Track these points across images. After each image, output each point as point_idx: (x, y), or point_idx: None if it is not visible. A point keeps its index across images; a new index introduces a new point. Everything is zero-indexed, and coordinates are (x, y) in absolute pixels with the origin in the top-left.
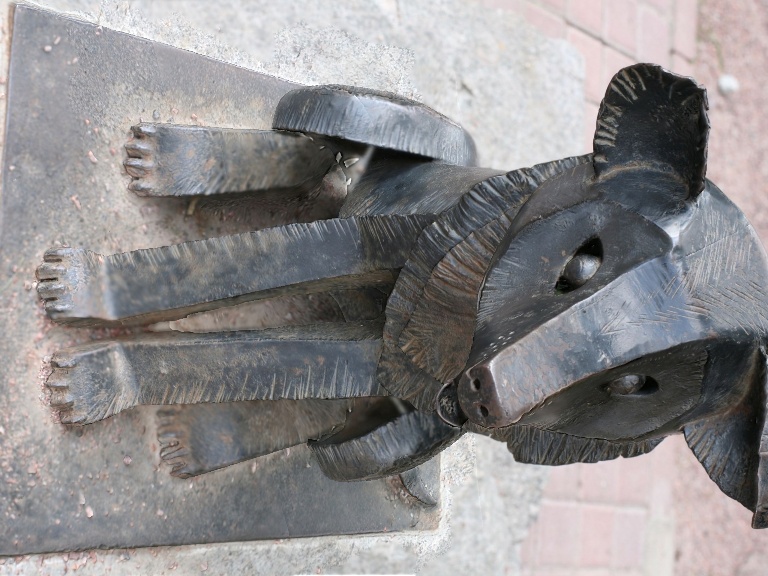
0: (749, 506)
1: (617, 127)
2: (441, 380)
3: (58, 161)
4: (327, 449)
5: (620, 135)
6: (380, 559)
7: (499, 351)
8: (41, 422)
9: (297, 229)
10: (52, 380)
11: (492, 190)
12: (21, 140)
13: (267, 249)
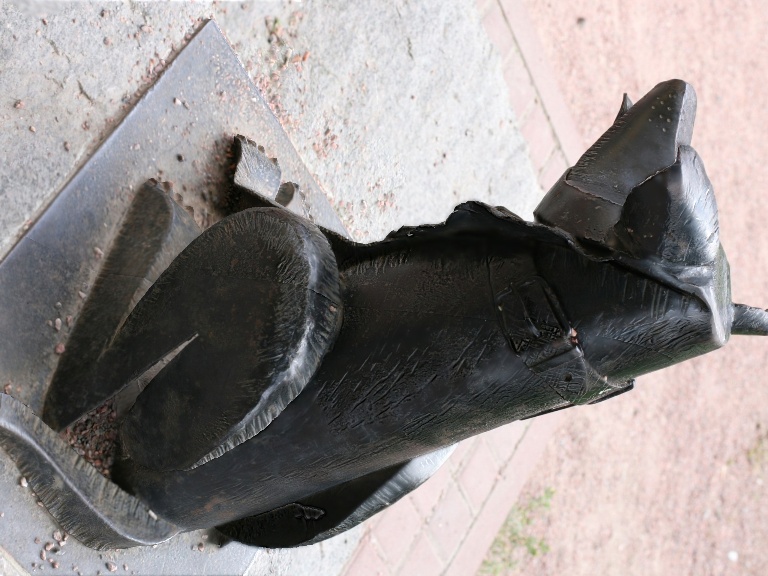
0: None
1: None
2: None
3: None
4: None
5: None
6: None
7: None
8: (239, 127)
9: None
10: None
11: None
12: None
13: None
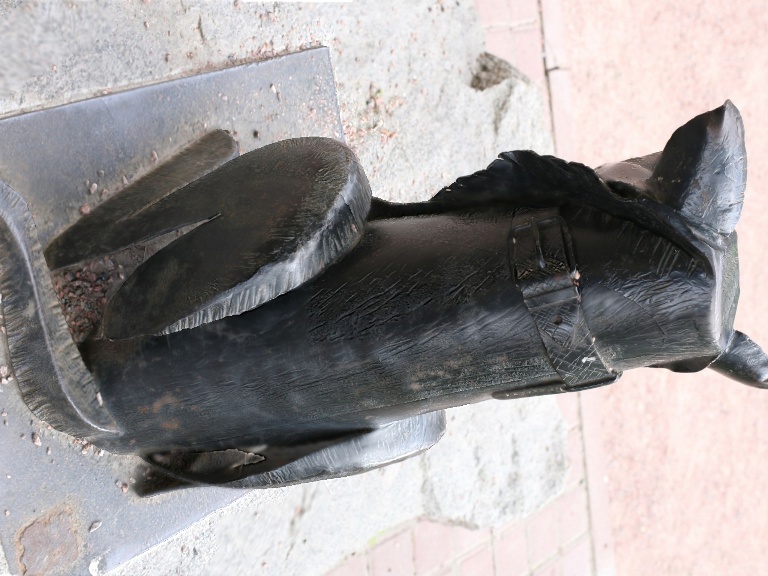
0: None
1: None
2: None
3: None
4: None
5: None
6: None
7: None
8: None
9: None
10: None
11: None
12: None
13: None
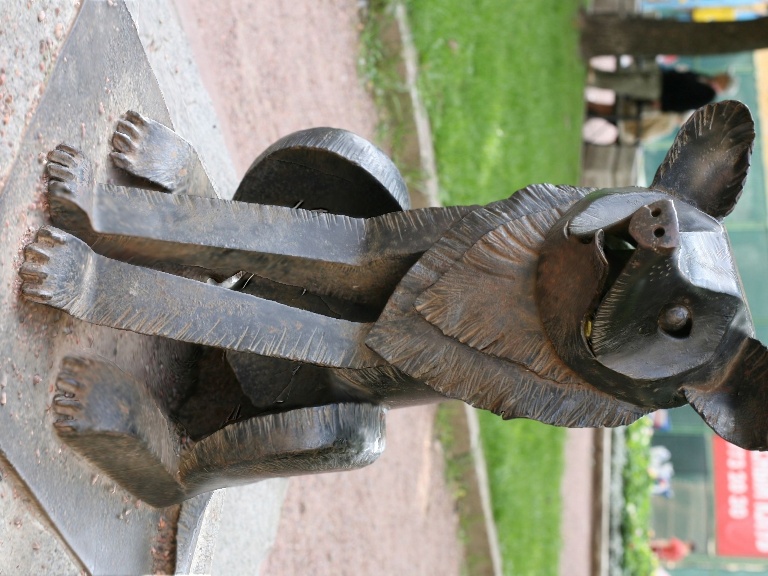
0: (742, 444)
1: (679, 153)
2: (456, 334)
3: (86, 87)
4: (266, 418)
5: (677, 161)
6: None
7: None
8: (7, 280)
9: (307, 214)
10: (35, 246)
11: (546, 191)
12: (76, 46)
13: (273, 221)
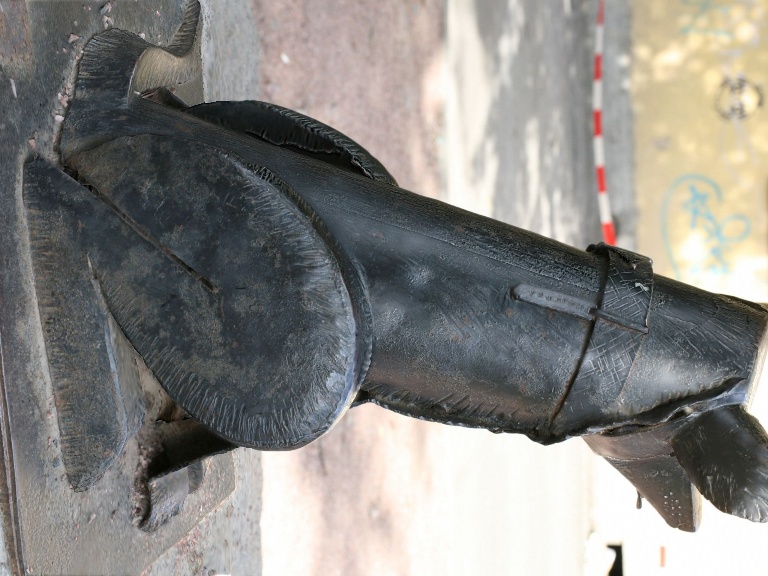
0: None
1: None
2: None
3: (99, 552)
4: None
5: None
6: (213, 73)
7: (692, 524)
8: None
9: None
10: None
11: None
12: None
13: None
